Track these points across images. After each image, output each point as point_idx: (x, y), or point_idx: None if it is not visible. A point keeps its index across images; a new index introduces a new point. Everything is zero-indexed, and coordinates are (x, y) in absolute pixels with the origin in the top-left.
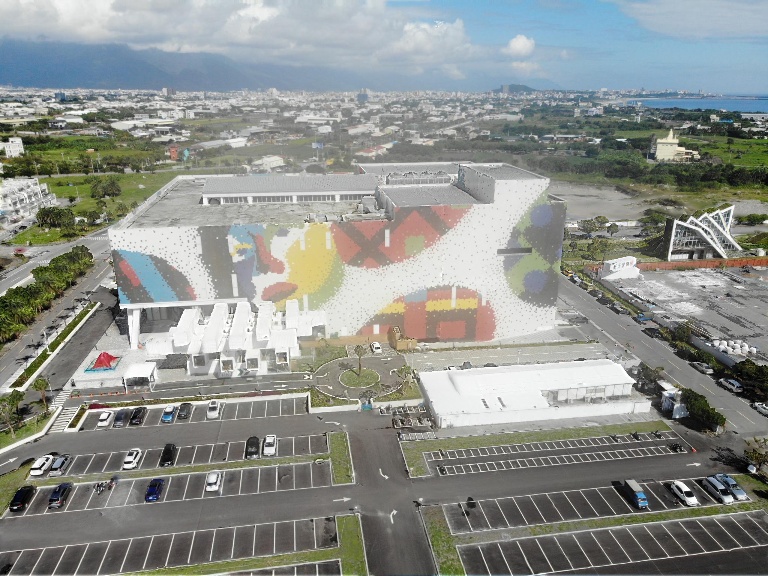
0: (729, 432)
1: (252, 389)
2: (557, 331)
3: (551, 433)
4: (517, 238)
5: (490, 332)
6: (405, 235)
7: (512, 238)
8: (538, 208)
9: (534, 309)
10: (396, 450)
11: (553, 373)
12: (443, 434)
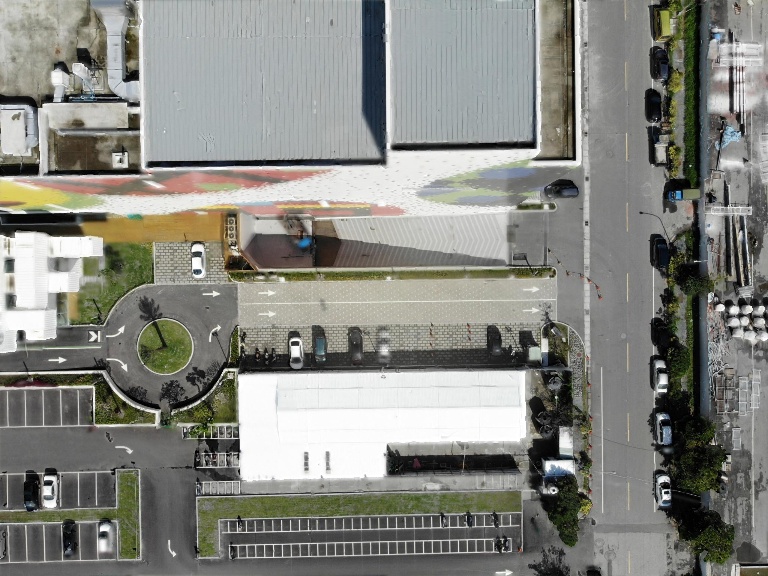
0: (586, 521)
1: (19, 365)
2: (509, 221)
3: (375, 501)
4: (445, 184)
5: (396, 213)
6: (191, 182)
7: (433, 185)
8: (500, 169)
9: (475, 207)
10: (190, 511)
11: (416, 416)
12: (250, 488)
